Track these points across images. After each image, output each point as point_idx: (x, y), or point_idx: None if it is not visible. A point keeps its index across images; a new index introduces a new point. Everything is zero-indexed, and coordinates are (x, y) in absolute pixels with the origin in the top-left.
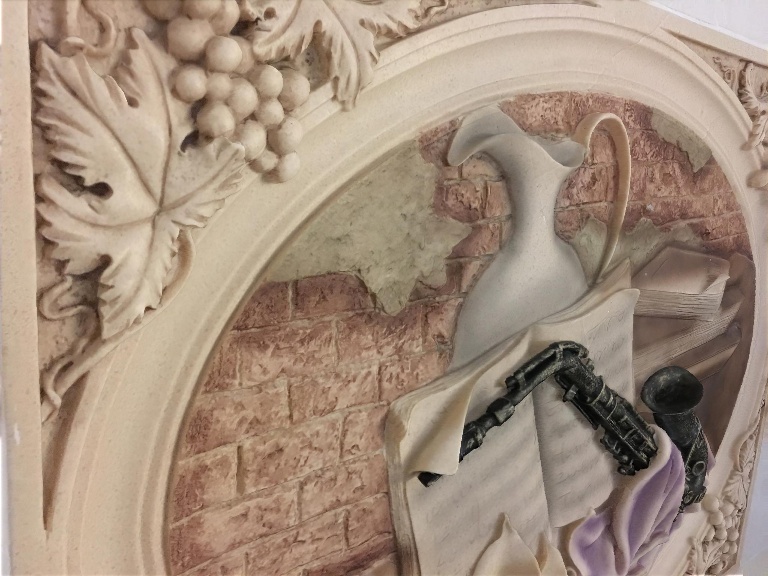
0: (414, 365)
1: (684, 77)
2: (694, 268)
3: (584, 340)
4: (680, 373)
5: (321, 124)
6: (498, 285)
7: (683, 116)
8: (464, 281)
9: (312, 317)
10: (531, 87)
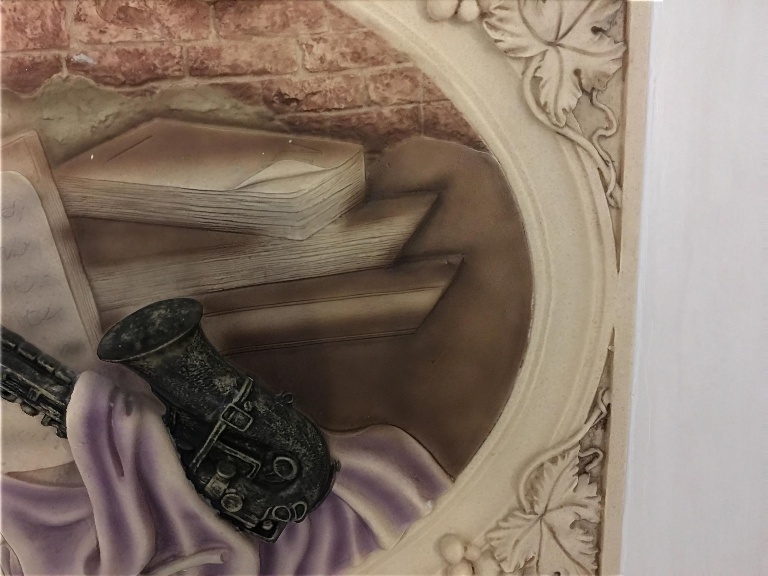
0: None
1: None
2: (227, 152)
3: None
4: (188, 309)
5: None
6: None
7: None
8: None
9: None
10: None
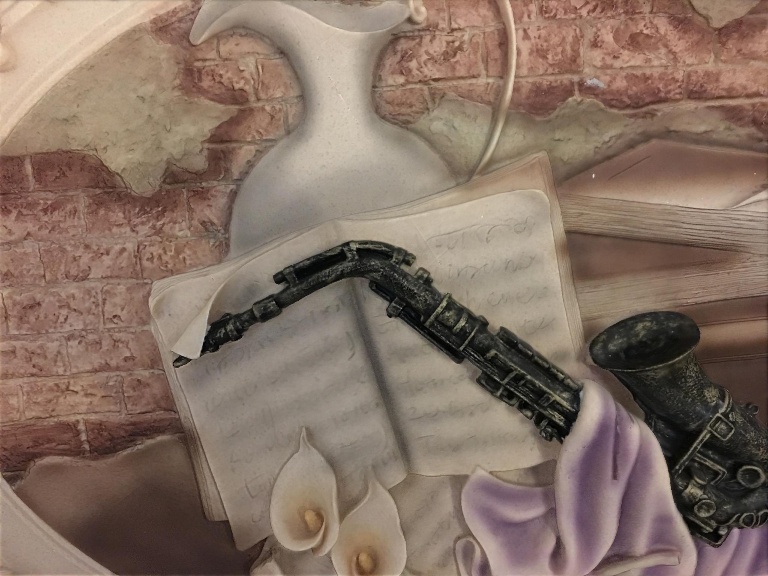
0: (180, 249)
1: None
2: (722, 172)
3: (426, 247)
4: (677, 322)
5: (31, 17)
6: (277, 172)
7: None
8: (235, 167)
9: (53, 190)
10: None
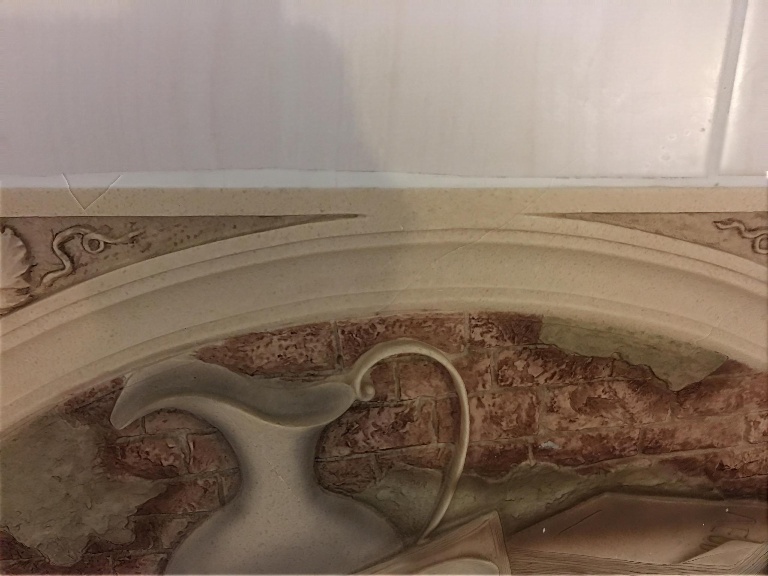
0: None
1: (626, 263)
2: (671, 524)
3: None
4: None
5: None
6: (211, 547)
7: (631, 316)
8: (165, 538)
9: None
10: (250, 327)
